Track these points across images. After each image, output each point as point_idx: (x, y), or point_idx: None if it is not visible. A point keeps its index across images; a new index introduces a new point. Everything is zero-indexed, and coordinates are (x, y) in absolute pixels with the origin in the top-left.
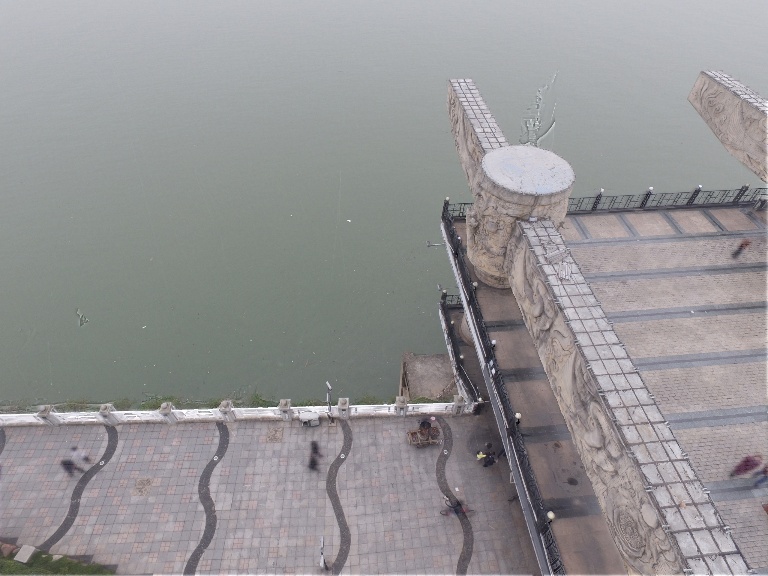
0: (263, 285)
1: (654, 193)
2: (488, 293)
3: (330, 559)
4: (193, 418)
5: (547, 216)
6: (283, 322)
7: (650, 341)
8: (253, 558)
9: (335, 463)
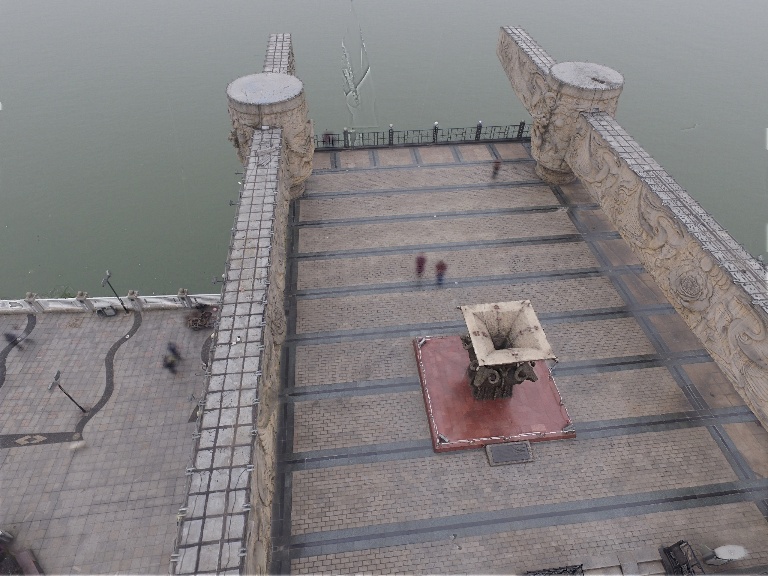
0: (104, 214)
1: (441, 128)
2: None
3: (90, 406)
4: (7, 310)
5: (278, 125)
6: (137, 254)
7: (386, 236)
8: (26, 405)
9: (119, 341)
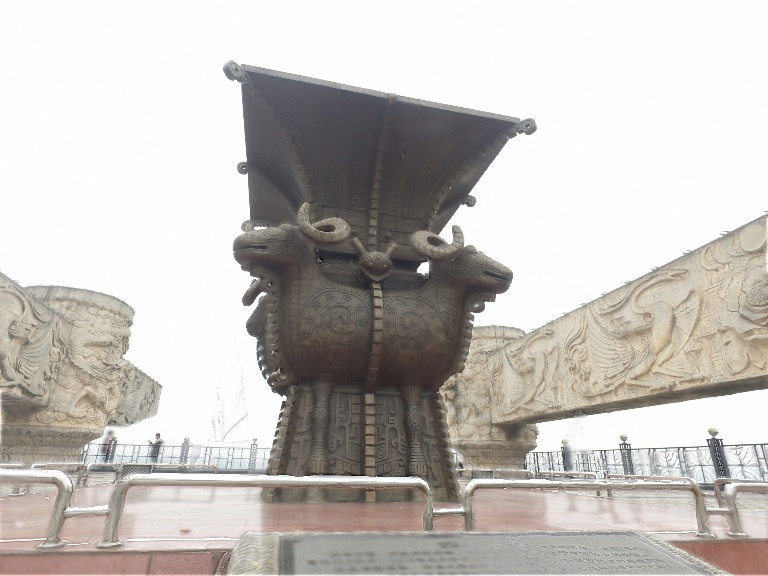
0: None
1: None
2: None
3: None
4: None
5: (67, 319)
6: None
7: None
8: None
9: None
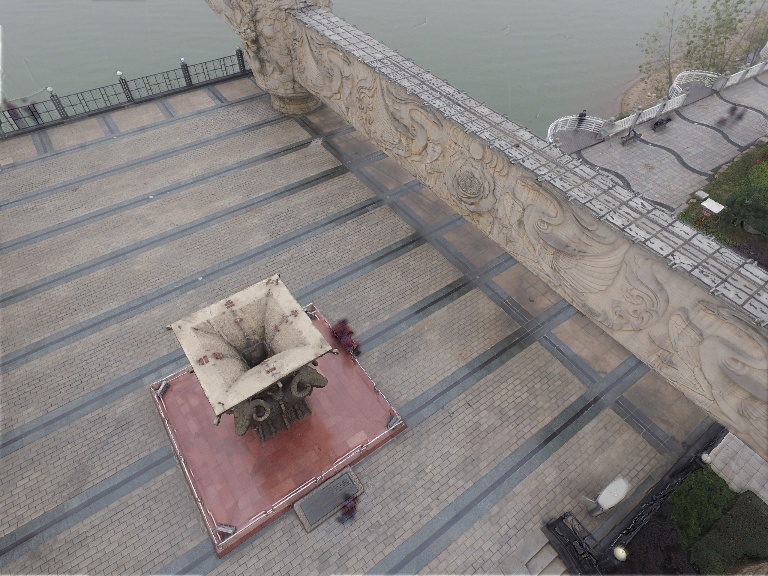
0: None
1: (130, 79)
2: None
3: None
4: None
5: None
6: None
7: (80, 248)
8: None
9: None
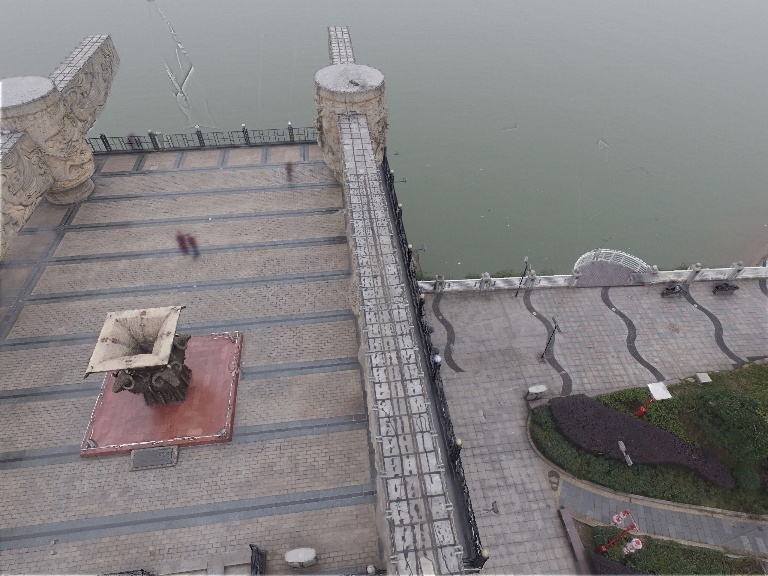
0: None
1: (250, 130)
2: (46, 208)
3: None
4: None
5: (20, 130)
6: None
7: (150, 240)
8: None
9: None
